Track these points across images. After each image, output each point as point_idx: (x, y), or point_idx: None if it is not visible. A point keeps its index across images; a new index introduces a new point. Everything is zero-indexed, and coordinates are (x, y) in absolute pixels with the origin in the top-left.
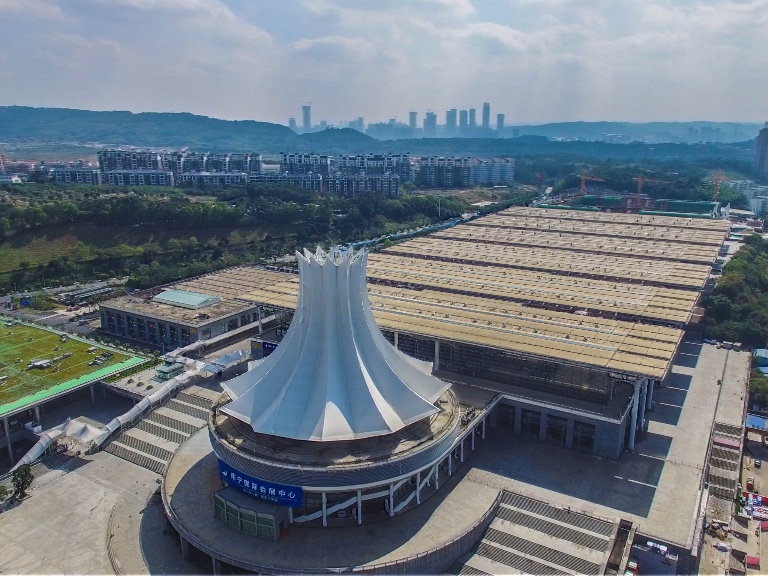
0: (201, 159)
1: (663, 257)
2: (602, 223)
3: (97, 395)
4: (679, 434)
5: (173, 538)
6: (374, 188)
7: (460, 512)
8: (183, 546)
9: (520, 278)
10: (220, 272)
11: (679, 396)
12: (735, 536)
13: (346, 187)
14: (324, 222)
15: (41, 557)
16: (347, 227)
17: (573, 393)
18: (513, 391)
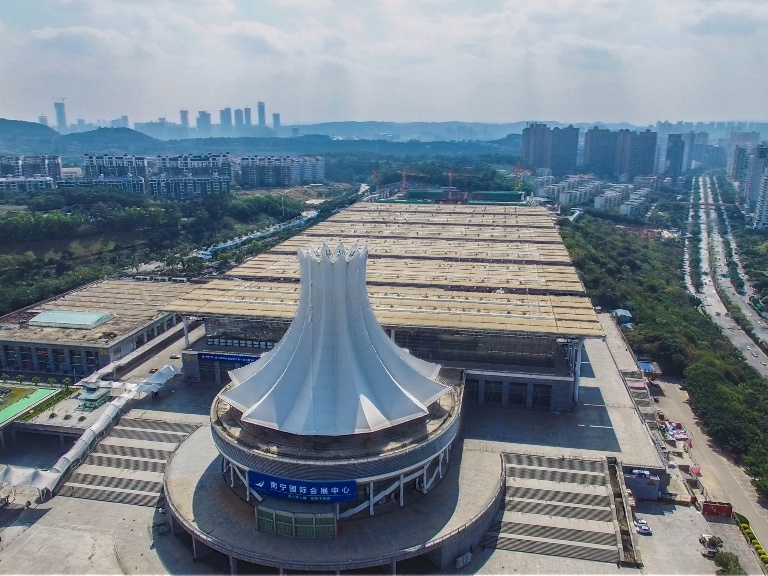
0: None
1: (521, 240)
2: (448, 214)
3: (6, 438)
4: (602, 384)
5: (207, 564)
6: (204, 190)
7: (481, 478)
8: (233, 567)
9: (423, 267)
10: (86, 287)
11: (582, 354)
12: (674, 455)
13: (173, 190)
14: (174, 227)
15: None
16: (199, 231)
17: (525, 361)
18: (473, 366)
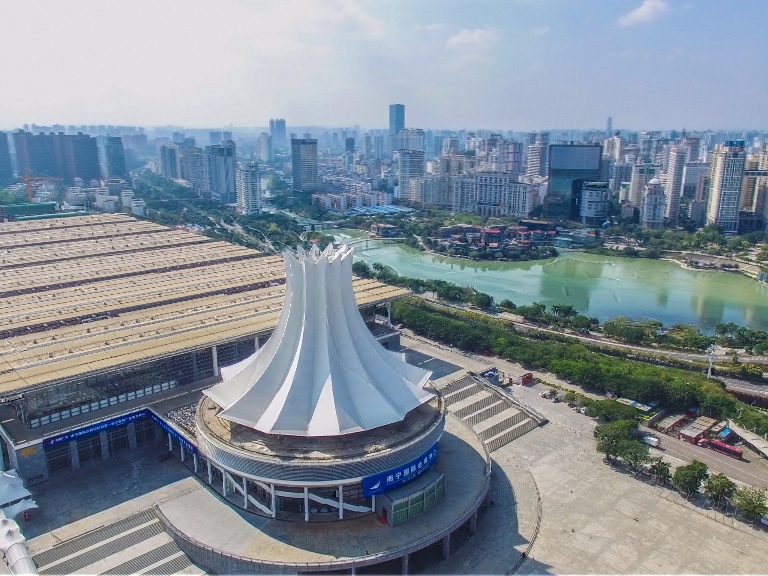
0: None
1: (177, 243)
2: (33, 232)
3: None
4: None
5: None
6: None
7: None
8: None
9: (158, 281)
10: None
11: None
12: None
13: None
14: None
15: None
16: None
17: None
18: None
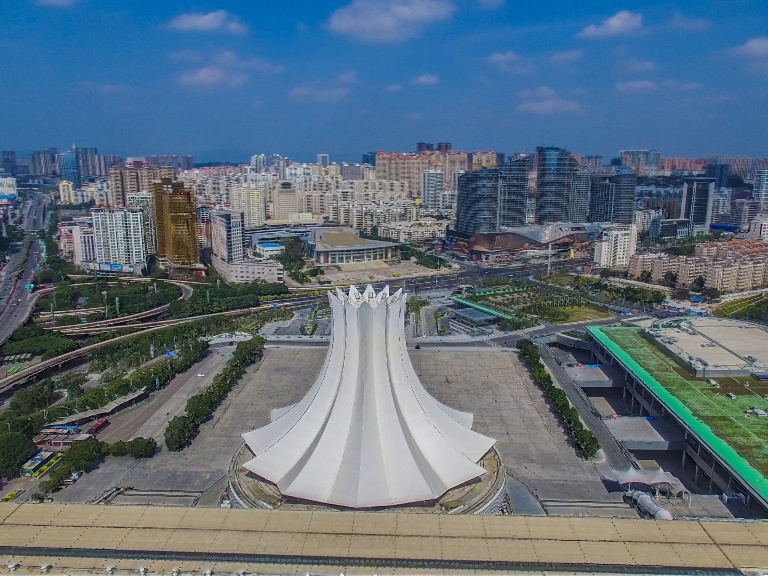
0: None
1: None
2: None
3: None
4: None
5: None
6: None
7: None
8: None
9: None
10: None
11: None
12: None
13: None
14: None
15: (498, 442)
16: None
17: None
18: None
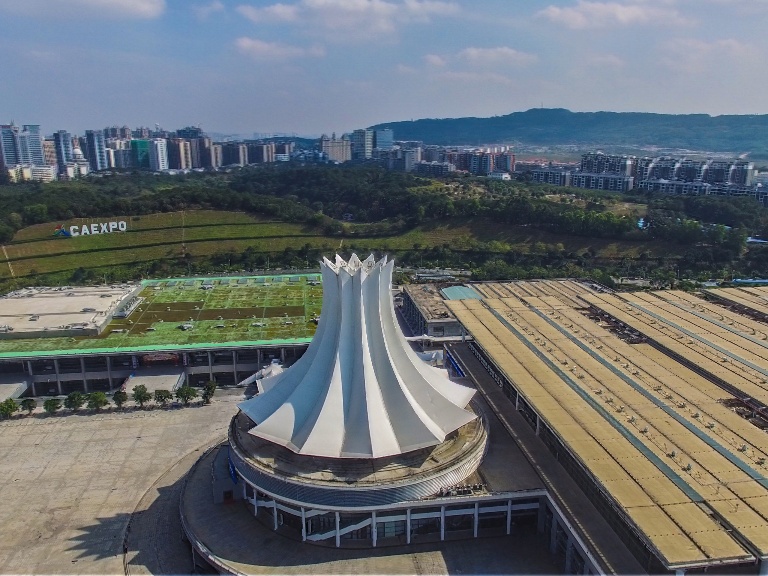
0: (672, 165)
1: None
2: None
3: None
4: None
5: None
6: None
7: None
8: None
9: None
10: (539, 281)
11: None
12: None
13: None
14: (728, 248)
15: (160, 442)
16: (760, 259)
17: (624, 534)
18: (568, 495)
